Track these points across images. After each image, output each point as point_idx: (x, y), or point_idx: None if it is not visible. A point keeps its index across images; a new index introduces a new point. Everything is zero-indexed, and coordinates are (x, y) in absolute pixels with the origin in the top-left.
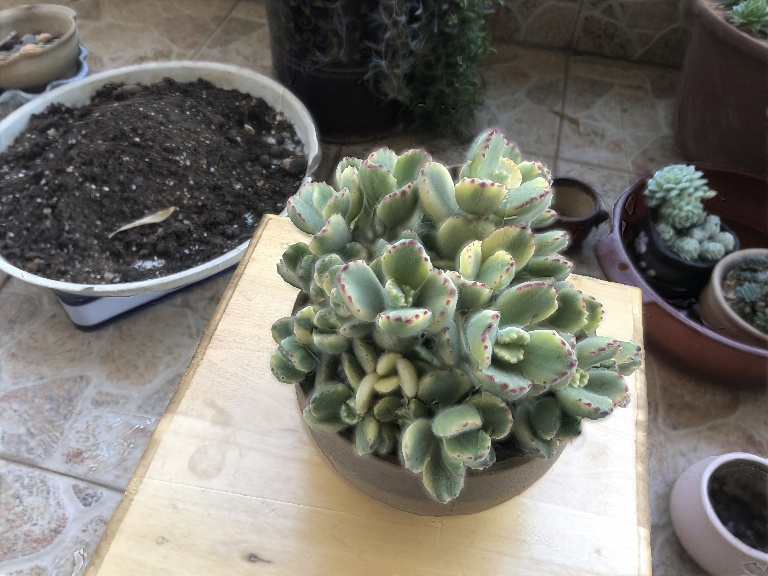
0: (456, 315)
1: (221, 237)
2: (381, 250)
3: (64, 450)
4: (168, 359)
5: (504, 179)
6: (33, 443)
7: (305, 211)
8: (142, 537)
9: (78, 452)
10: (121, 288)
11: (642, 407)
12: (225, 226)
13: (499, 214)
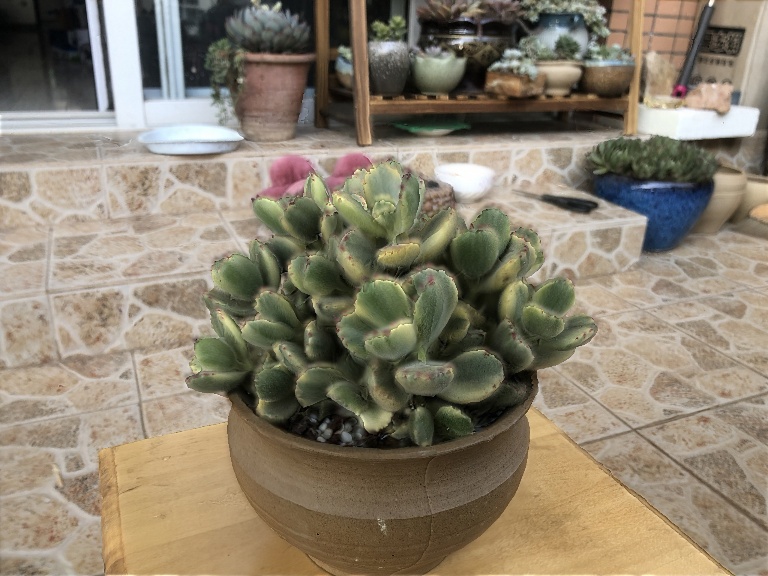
0: None
1: None
2: None
3: None
4: None
5: None
6: None
7: None
8: None
9: None
10: None
11: None
12: None
13: None
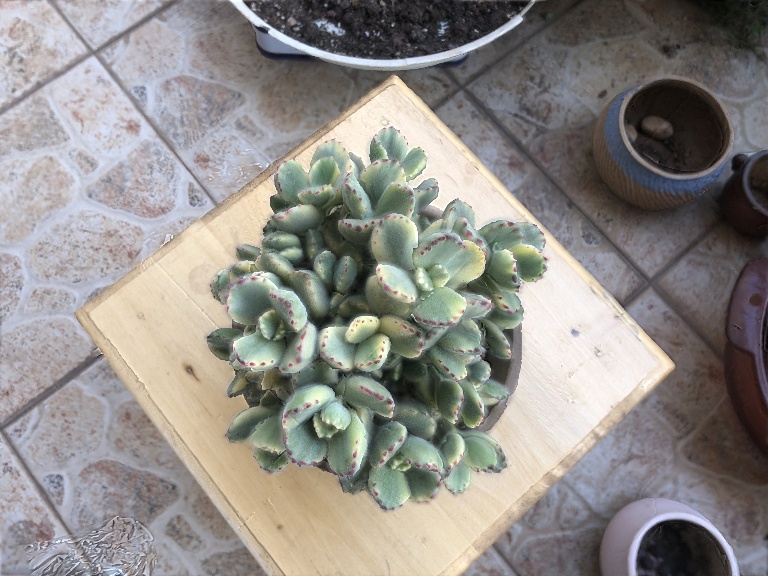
0: (317, 364)
1: (404, 36)
2: (315, 262)
3: (198, 150)
4: (312, 119)
5: (442, 277)
6: (180, 130)
7: (289, 182)
8: (131, 305)
9: (206, 158)
10: (290, 43)
11: (566, 465)
12: (415, 26)
13: (412, 306)
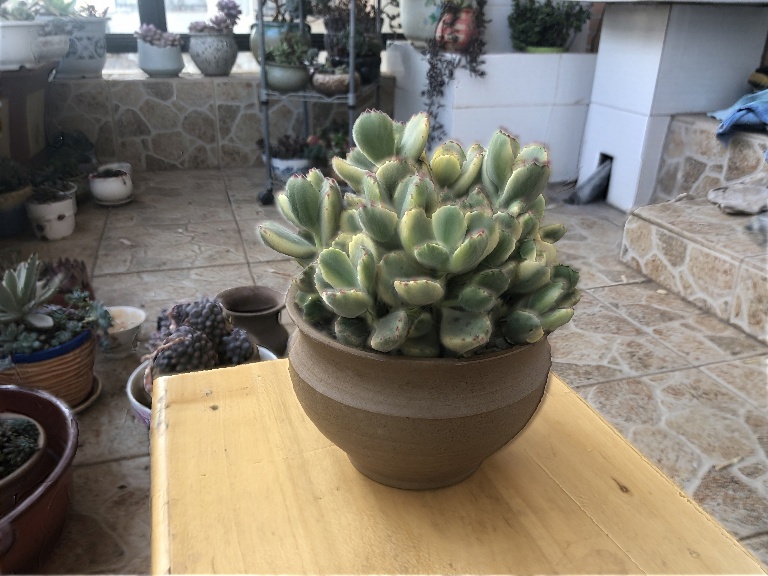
0: None
1: None
2: None
3: None
4: None
5: None
6: None
7: None
8: (711, 570)
9: None
10: None
11: None
12: None
13: None
